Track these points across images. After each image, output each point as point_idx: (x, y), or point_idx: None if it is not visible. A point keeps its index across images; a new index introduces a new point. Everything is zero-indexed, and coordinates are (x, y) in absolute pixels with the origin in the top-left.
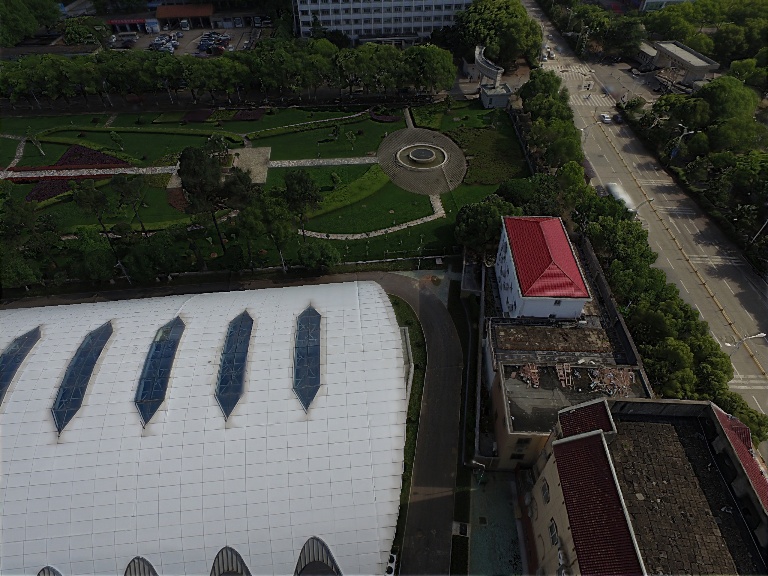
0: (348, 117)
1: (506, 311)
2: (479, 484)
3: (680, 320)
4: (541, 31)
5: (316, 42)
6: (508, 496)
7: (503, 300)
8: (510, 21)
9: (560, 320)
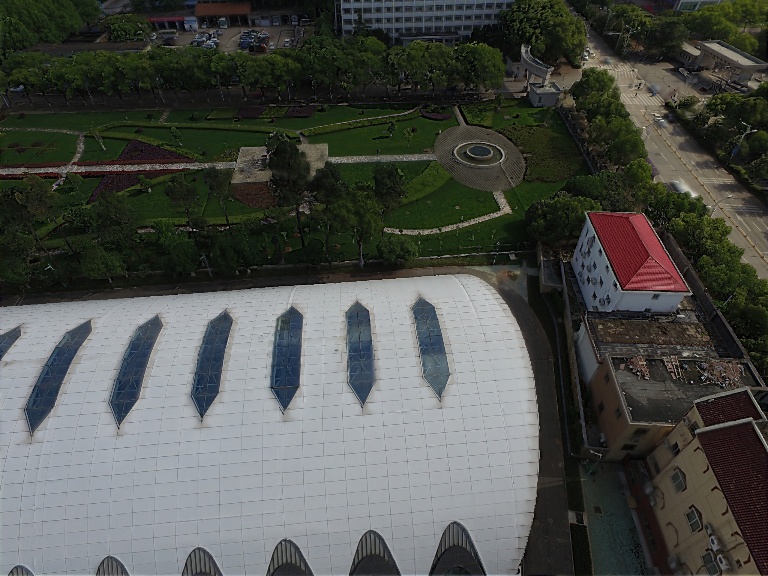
0: (399, 114)
1: (593, 305)
2: (589, 474)
3: None
4: (585, 30)
5: (366, 40)
6: (619, 486)
7: (586, 295)
8: (556, 20)
9: (656, 314)
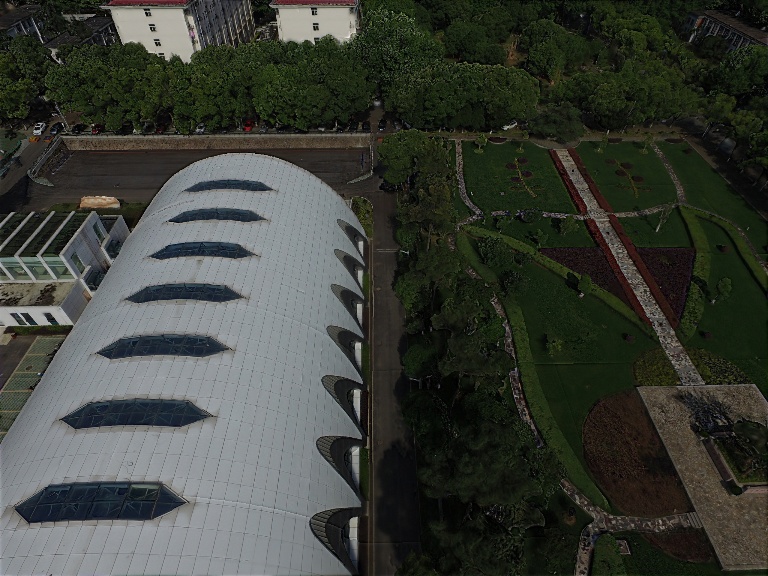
0: None
1: None
2: None
3: None
4: None
5: None
6: None
7: None
8: None
9: None
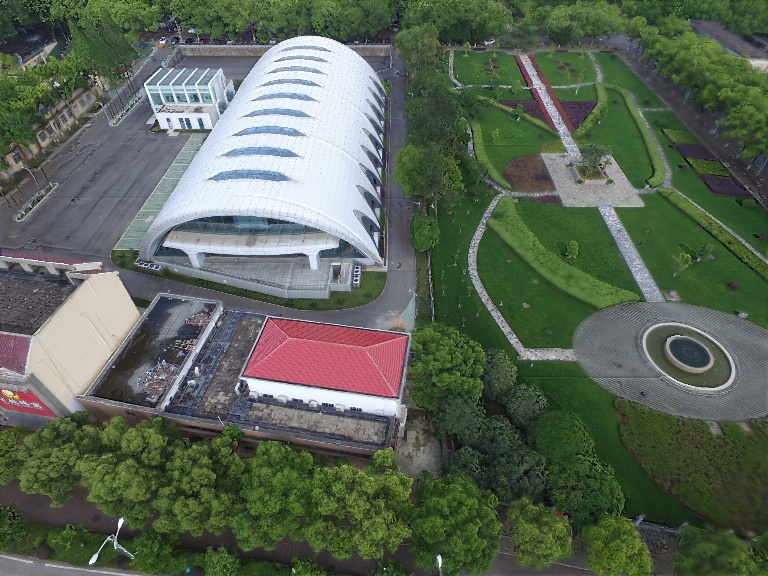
0: None
1: None
2: None
3: (175, 472)
4: None
5: None
6: None
7: None
8: None
9: None
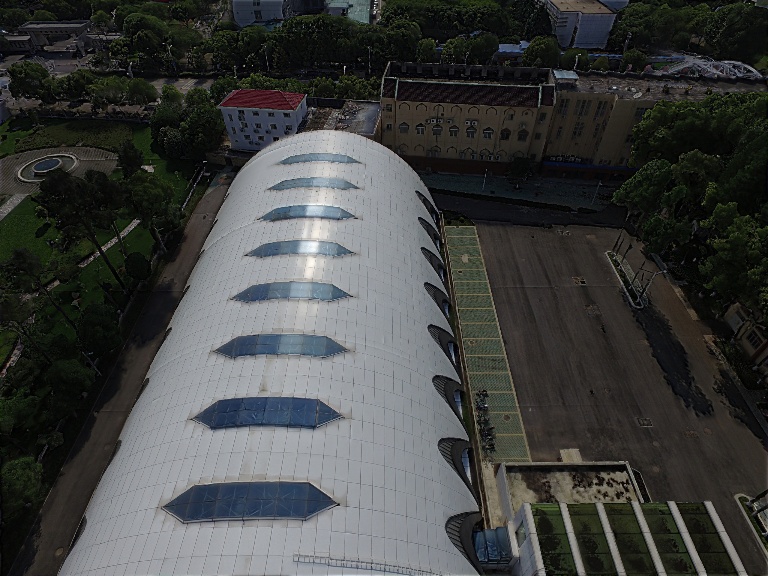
0: None
1: None
2: None
3: None
4: None
5: None
6: None
7: None
8: None
9: (306, 117)
